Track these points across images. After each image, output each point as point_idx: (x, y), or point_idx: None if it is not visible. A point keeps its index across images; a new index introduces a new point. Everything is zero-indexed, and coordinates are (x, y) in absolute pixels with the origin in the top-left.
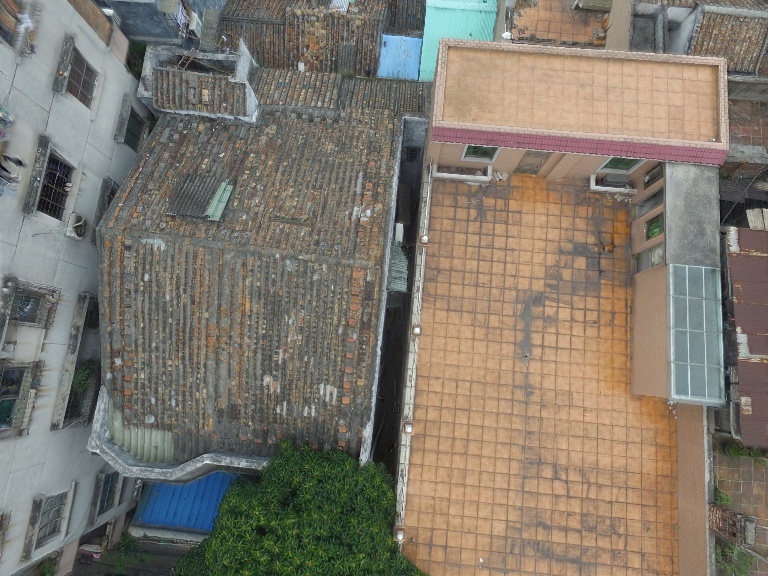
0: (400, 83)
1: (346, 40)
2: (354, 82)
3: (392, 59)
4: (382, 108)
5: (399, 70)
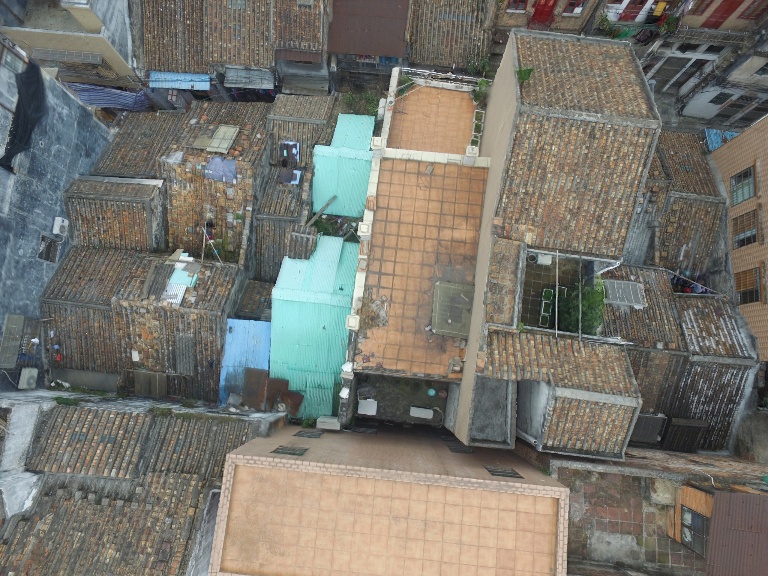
0: (222, 423)
1: (182, 331)
2: (168, 422)
3: (239, 345)
4: (192, 469)
5: (247, 357)
